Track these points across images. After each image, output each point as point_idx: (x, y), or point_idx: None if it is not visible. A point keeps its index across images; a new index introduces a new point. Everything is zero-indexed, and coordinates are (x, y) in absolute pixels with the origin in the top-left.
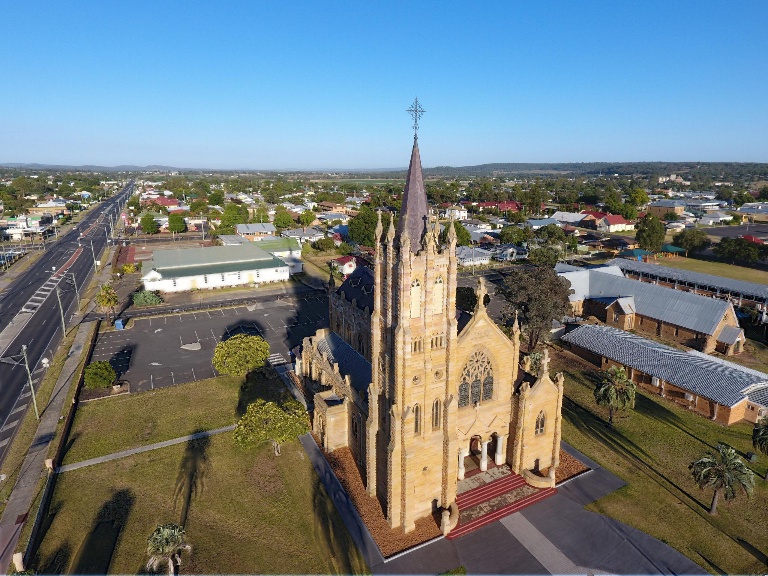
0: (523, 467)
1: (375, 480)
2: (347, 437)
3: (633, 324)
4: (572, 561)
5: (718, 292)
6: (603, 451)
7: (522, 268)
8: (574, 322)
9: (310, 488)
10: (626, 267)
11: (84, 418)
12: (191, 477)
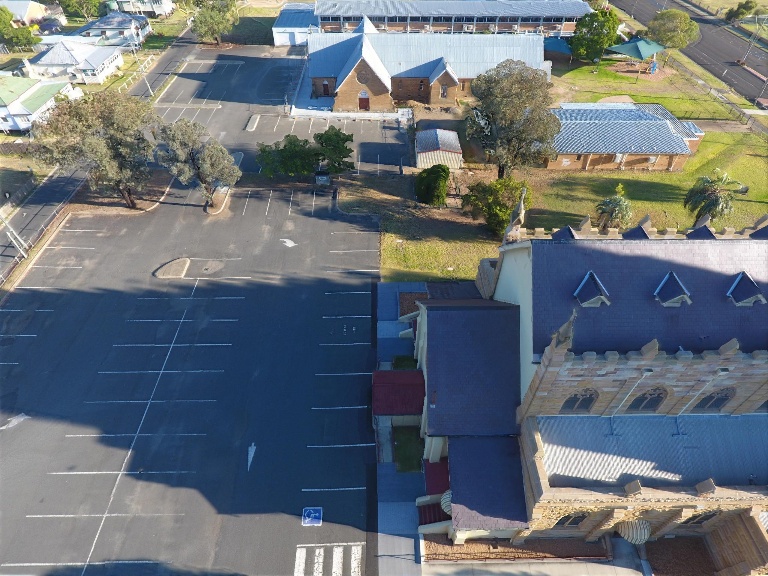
0: None
1: None
2: None
3: None
4: None
5: (453, 21)
6: None
7: (184, 53)
8: None
9: None
10: (346, 13)
11: None
12: None
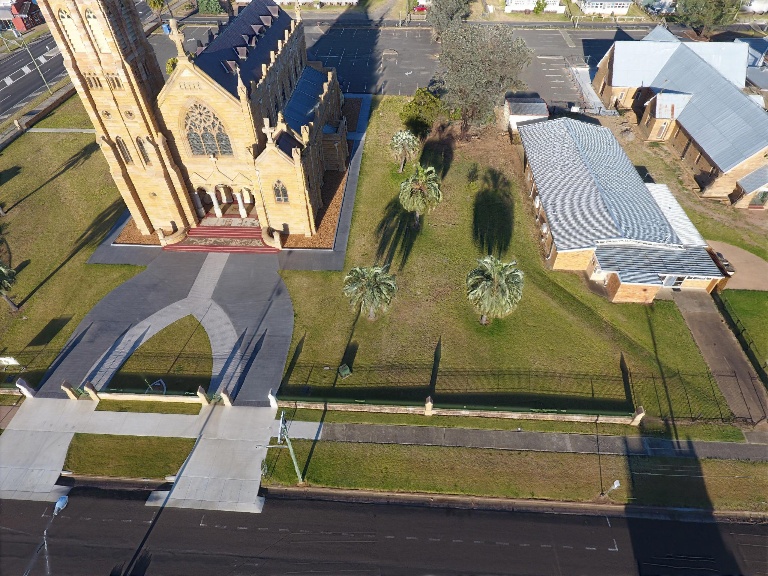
0: (263, 225)
1: None
2: None
3: (669, 135)
4: (212, 294)
5: None
6: (370, 241)
7: None
8: (596, 115)
9: None
10: None
11: (74, 100)
12: (81, 157)
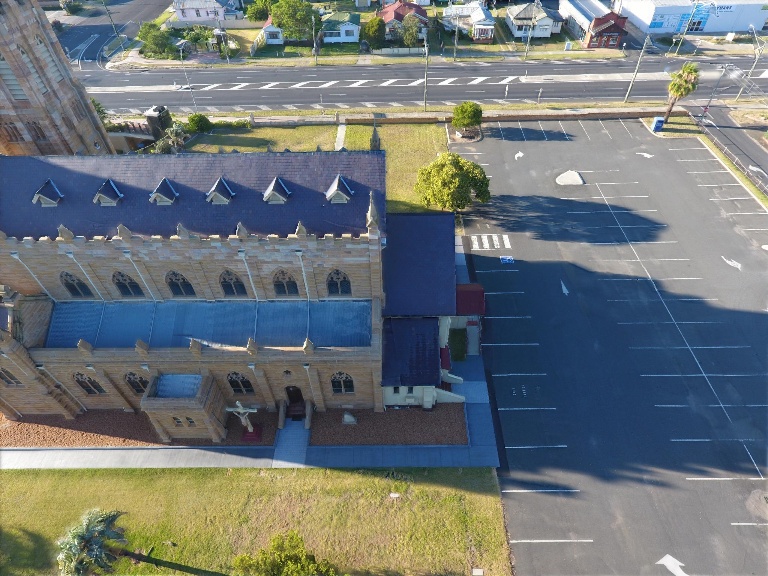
0: None
1: None
2: None
3: None
4: None
5: None
6: None
7: None
8: None
9: None
10: None
11: (413, 127)
12: None
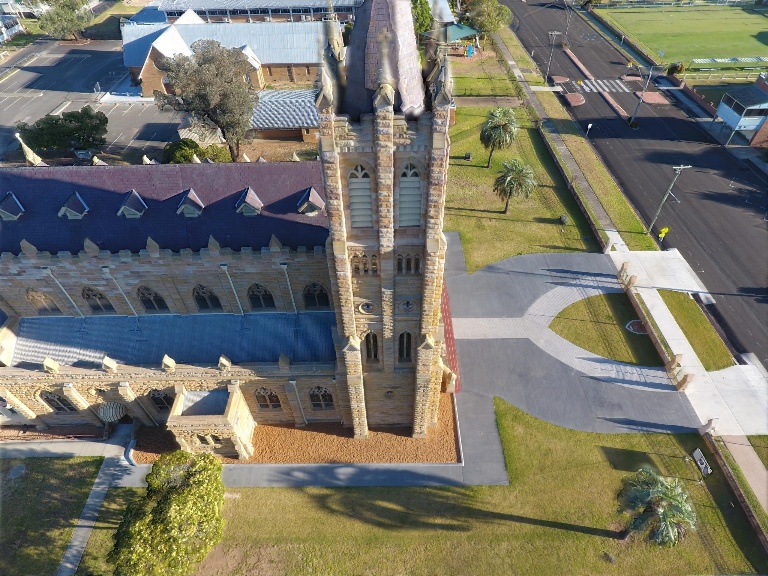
0: None
1: (366, 421)
2: (251, 418)
3: (263, 78)
4: (517, 317)
5: (291, 12)
6: None
7: (40, 49)
8: None
9: (307, 508)
10: (187, 7)
11: None
12: None
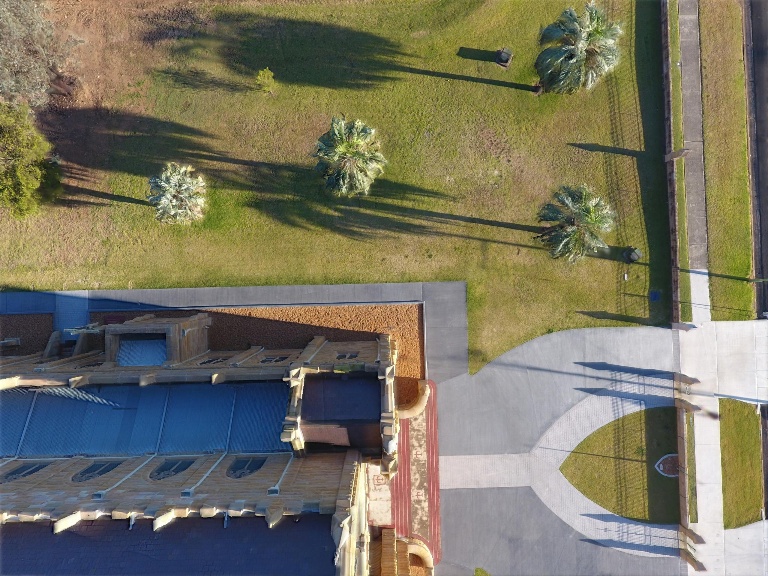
0: None
1: None
2: None
3: None
4: (523, 453)
5: None
6: (398, 248)
7: None
8: None
9: None
10: None
11: None
12: None
